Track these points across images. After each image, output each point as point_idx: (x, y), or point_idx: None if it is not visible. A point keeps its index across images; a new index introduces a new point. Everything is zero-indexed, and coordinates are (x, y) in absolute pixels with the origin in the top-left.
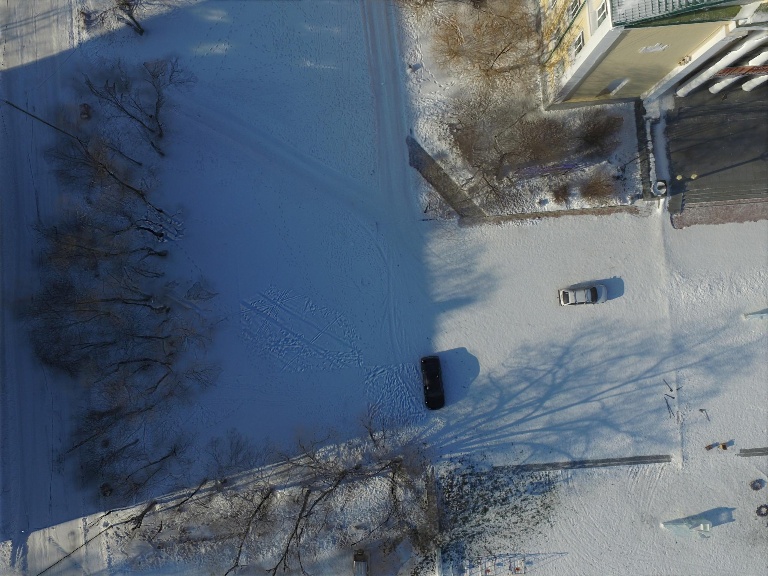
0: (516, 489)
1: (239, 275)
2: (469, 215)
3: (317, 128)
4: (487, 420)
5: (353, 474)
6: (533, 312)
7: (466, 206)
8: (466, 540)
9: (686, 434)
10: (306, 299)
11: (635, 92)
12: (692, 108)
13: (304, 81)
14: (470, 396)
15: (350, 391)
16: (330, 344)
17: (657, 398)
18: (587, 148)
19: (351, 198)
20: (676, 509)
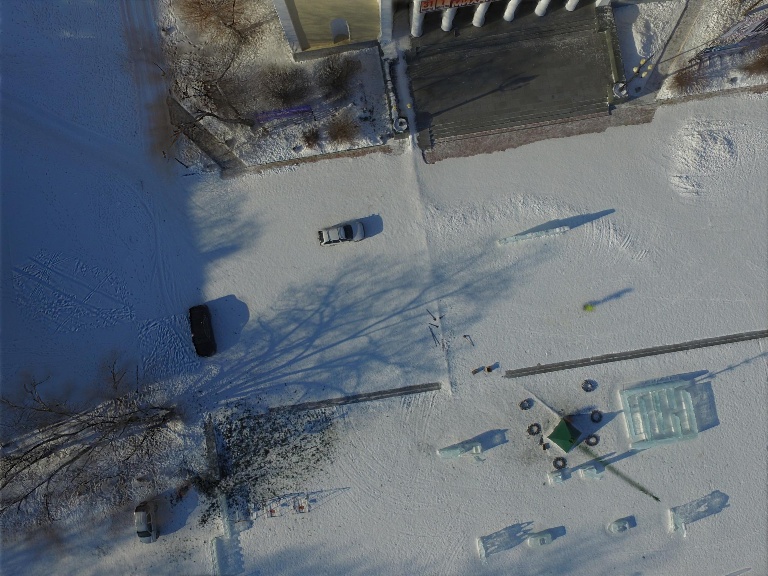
0: (294, 429)
1: (10, 242)
2: (231, 167)
3: (79, 95)
4: (260, 363)
5: (132, 427)
6: (297, 255)
7: (228, 159)
8: (249, 484)
9: (452, 360)
10: (76, 260)
11: (368, 35)
12: (429, 47)
13: (65, 52)
14: (242, 341)
15: (124, 346)
16: (102, 302)
17: (422, 328)
18: (336, 93)
19: (116, 160)
20: (451, 435)
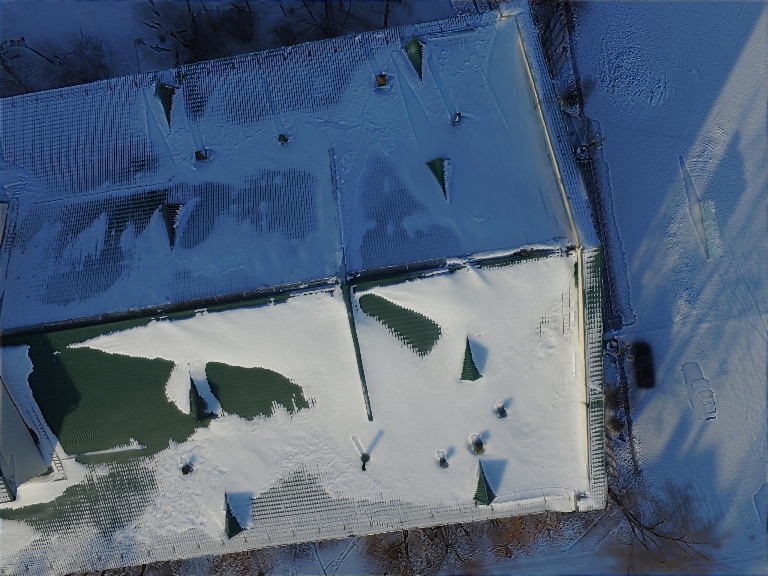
0: None
1: None
2: (634, 497)
3: None
4: None
5: None
6: (718, 439)
7: (626, 500)
8: None
9: None
10: None
11: None
12: None
13: None
14: None
15: None
16: None
17: None
18: None
19: None
20: None
